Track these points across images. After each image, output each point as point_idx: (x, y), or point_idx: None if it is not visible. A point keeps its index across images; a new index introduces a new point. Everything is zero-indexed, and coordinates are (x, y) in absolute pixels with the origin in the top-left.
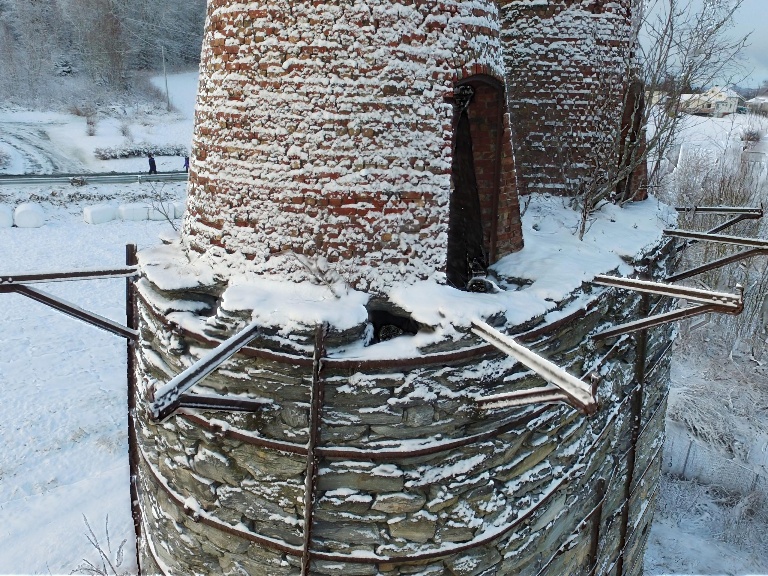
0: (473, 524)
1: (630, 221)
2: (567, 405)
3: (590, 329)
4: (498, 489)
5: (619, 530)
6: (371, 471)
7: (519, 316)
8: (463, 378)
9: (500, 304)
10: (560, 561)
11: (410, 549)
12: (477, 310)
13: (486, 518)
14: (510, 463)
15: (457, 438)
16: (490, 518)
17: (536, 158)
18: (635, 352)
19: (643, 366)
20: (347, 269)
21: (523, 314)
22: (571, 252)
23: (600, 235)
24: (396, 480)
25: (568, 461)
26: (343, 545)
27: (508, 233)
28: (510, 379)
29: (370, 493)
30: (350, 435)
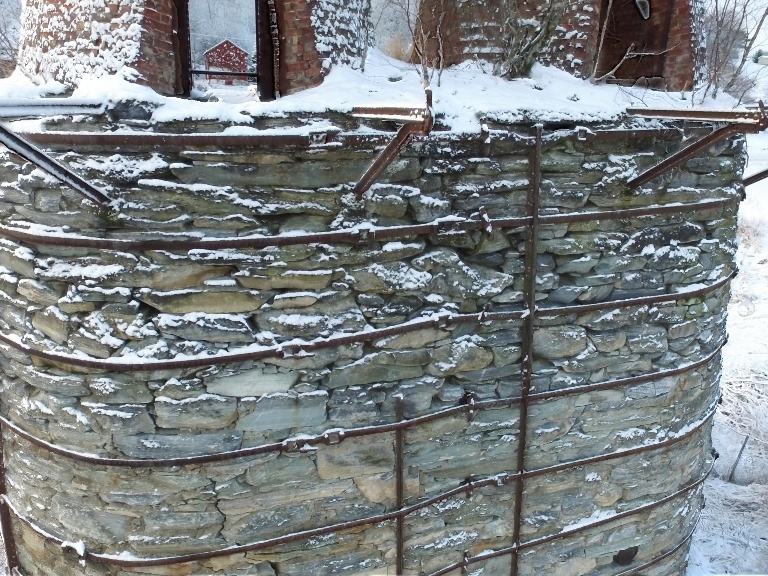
0: (106, 340)
1: (569, 91)
2: (283, 258)
3: (353, 179)
4: (152, 317)
5: (513, 513)
6: (14, 251)
7: (167, 112)
8: (86, 167)
9: (141, 93)
10: (300, 465)
11: (46, 345)
12: (105, 92)
13: (132, 344)
14: (166, 291)
15: (85, 235)
16: (136, 346)
17: (476, 16)
18: (523, 262)
19: (532, 283)
20: (52, 59)
21: (174, 111)
22: (385, 94)
23: (473, 91)
24: (27, 264)
25: (287, 331)
26: (6, 325)
27: (301, 63)
28: (148, 183)
29: (21, 277)
30: (1, 210)
